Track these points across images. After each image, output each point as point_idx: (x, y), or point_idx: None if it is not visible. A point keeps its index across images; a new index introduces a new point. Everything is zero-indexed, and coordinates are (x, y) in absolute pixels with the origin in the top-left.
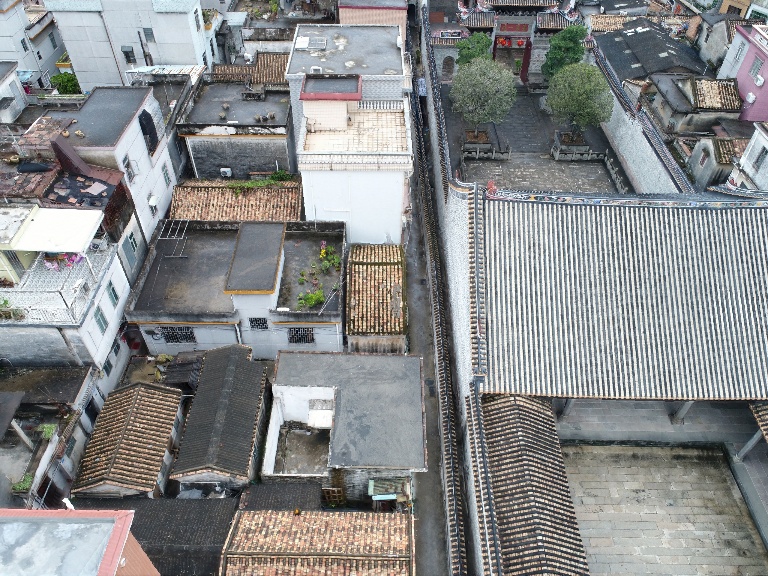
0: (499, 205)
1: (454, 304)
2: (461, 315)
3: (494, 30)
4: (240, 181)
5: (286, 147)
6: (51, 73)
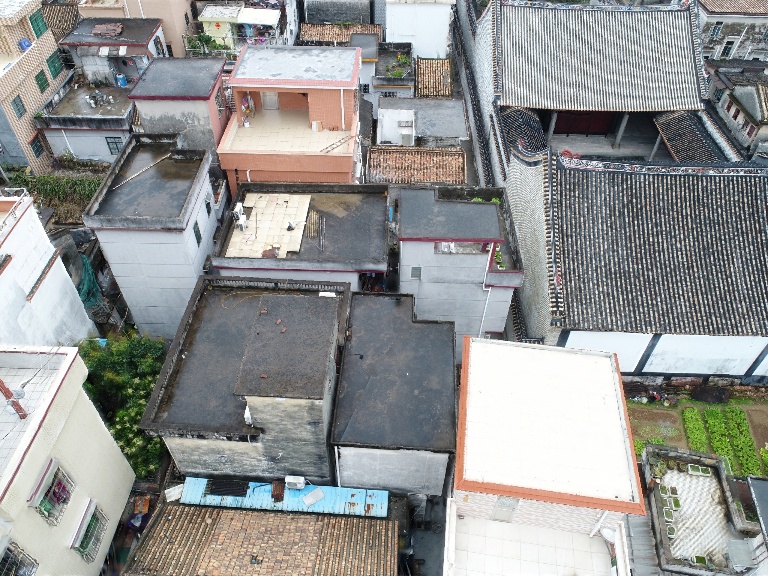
0: (510, 8)
1: (481, 87)
2: (486, 82)
3: None
4: None
5: (369, 6)
6: None
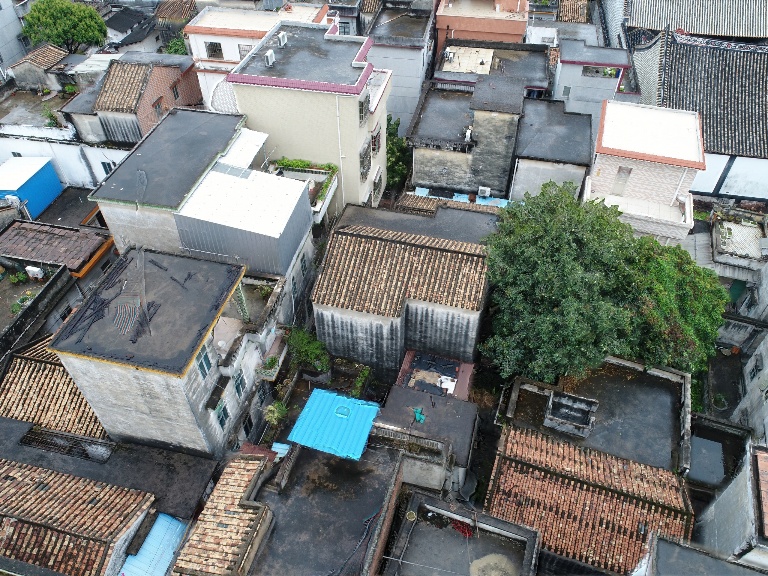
0: None
1: None
2: None
3: None
4: None
5: None
6: None
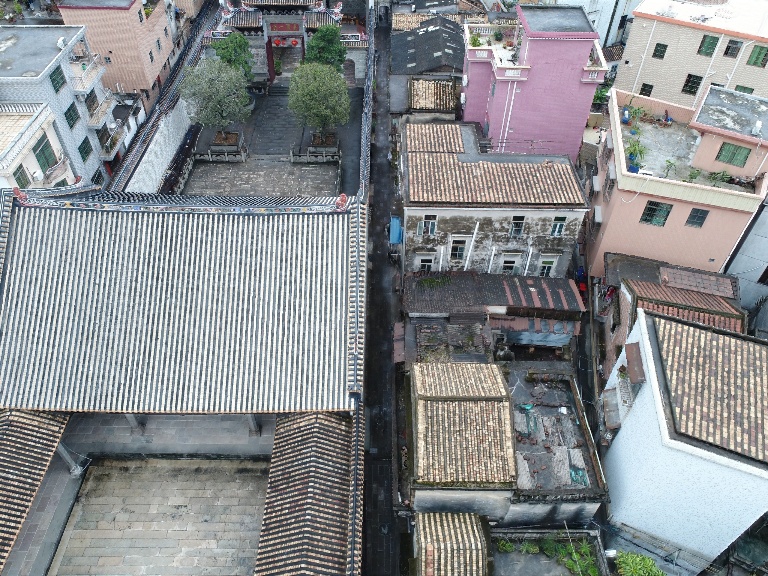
0: (35, 212)
1: None
2: None
3: (265, 30)
4: None
5: None
6: None
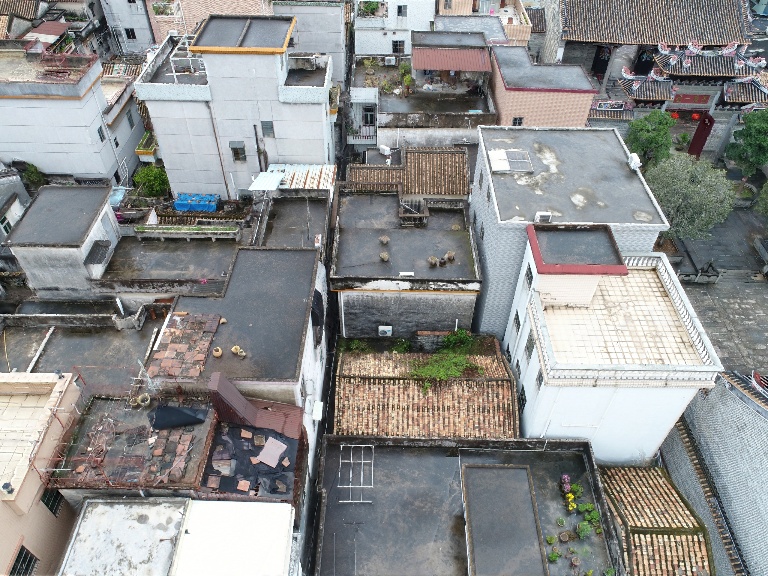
0: None
1: None
2: None
3: (666, 102)
4: (417, 357)
5: (473, 303)
6: (128, 160)
